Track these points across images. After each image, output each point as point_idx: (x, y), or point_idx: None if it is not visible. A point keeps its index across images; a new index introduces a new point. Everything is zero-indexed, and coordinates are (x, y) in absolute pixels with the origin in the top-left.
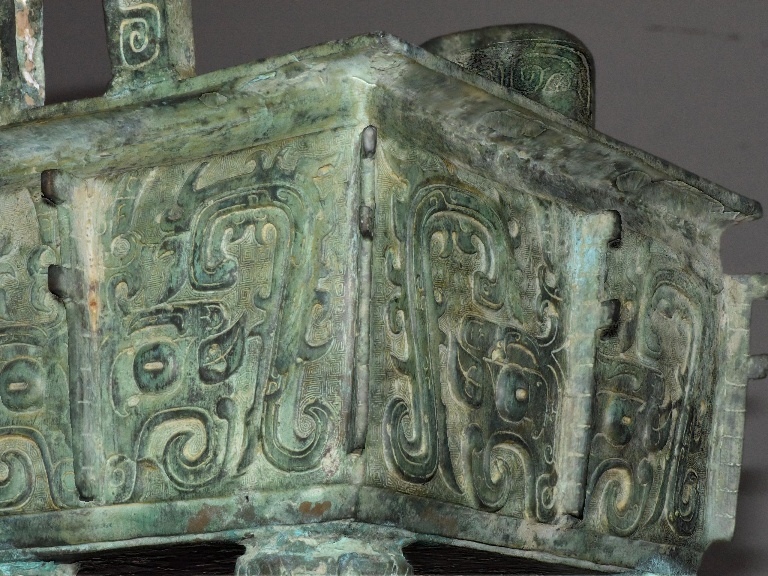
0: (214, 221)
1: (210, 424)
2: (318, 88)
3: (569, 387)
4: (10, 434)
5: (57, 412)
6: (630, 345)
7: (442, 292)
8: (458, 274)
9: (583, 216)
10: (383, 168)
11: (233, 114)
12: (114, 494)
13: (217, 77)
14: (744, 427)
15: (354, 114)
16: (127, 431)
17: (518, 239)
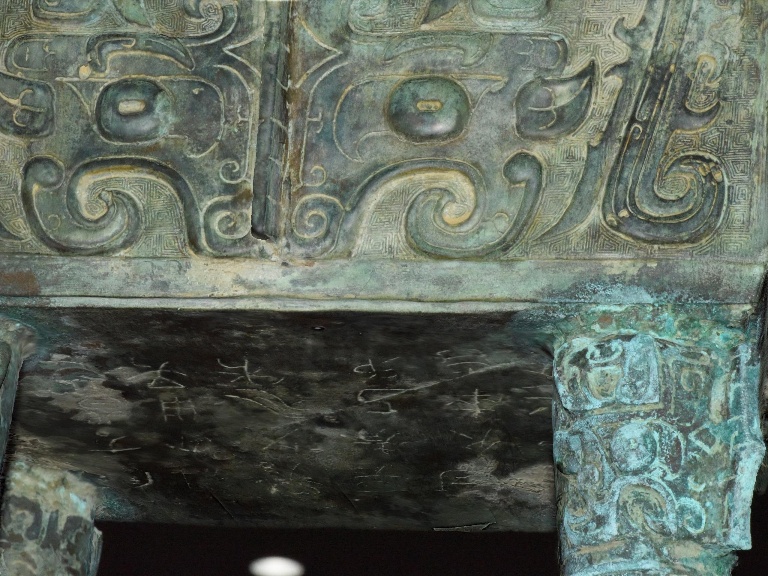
0: None
1: None
2: None
3: None
4: None
5: None
6: (446, 11)
7: None
8: None
9: None
10: None
11: None
12: None
13: None
14: None
15: None
16: None
17: None
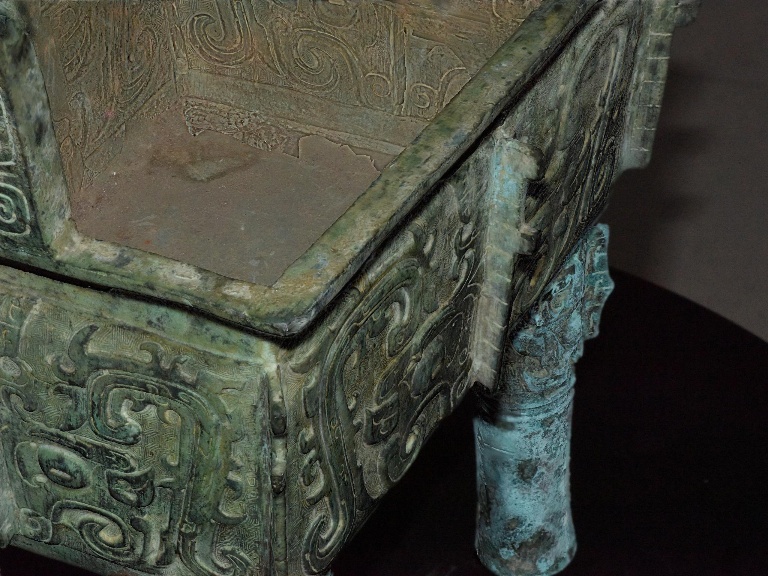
0: (111, 390)
1: (125, 529)
2: None
3: (485, 286)
4: None
5: None
6: (549, 162)
7: (356, 392)
8: (372, 356)
9: (503, 142)
10: (292, 379)
11: None
12: (31, 534)
13: (101, 279)
14: (666, 72)
15: (258, 352)
16: (38, 499)
17: (434, 246)
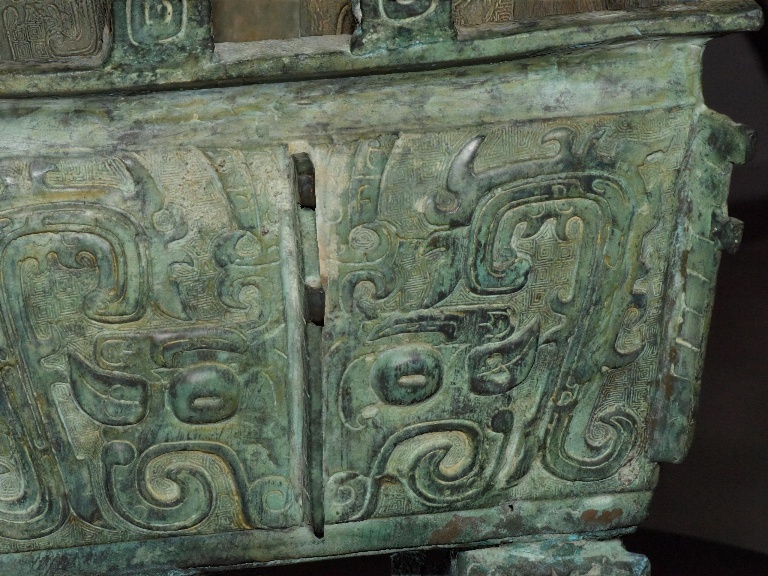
0: (504, 214)
1: (480, 438)
2: (640, 53)
3: None
4: (185, 450)
5: (256, 425)
6: None
7: None
8: None
9: None
10: None
11: (506, 69)
12: (339, 514)
13: (521, 44)
14: None
15: (691, 90)
16: (362, 446)
17: None
